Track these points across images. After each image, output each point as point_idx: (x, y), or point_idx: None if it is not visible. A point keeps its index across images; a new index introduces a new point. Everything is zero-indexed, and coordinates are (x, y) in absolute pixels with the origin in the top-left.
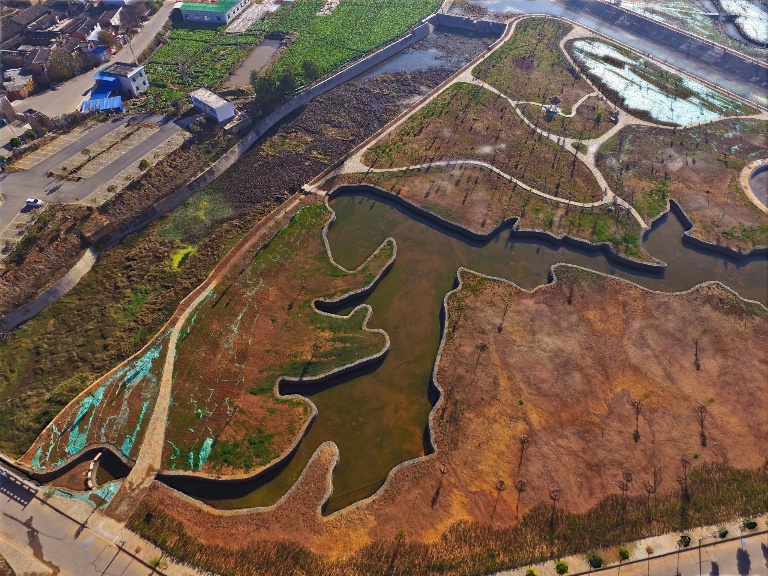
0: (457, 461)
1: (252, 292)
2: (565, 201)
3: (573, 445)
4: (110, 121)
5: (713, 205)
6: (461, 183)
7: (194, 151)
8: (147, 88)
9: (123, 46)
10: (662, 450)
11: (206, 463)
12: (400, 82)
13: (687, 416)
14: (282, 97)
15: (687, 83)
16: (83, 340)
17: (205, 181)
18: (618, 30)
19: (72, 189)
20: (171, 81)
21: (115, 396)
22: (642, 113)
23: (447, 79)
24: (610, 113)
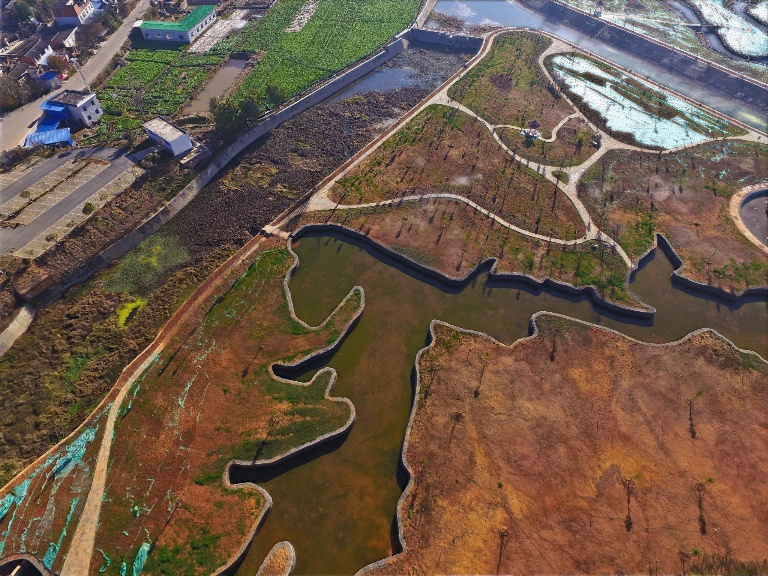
0: (428, 562)
1: (203, 356)
2: (546, 238)
3: (558, 537)
4: (56, 157)
5: (703, 239)
6: (435, 220)
7: (147, 189)
8: (100, 117)
9: (77, 70)
10: (657, 540)
11: (141, 575)
12: (372, 104)
13: (683, 496)
14: (244, 125)
15: (671, 101)
16: (12, 418)
17: (159, 222)
18: (599, 43)
19: (8, 238)
20: (127, 108)
21: (41, 492)
22: (625, 136)
23: (421, 101)
24: (592, 137)
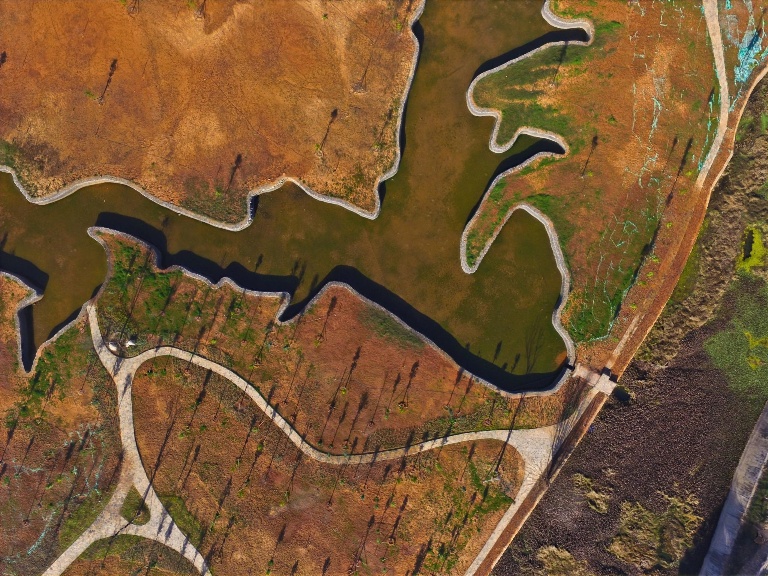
0: None
1: (648, 162)
2: (198, 359)
3: None
4: None
5: None
6: (358, 401)
7: None
8: None
9: None
10: None
11: None
12: None
13: (151, 2)
14: None
15: None
16: None
17: None
18: None
19: None
20: None
21: (764, 18)
22: None
23: None
24: None
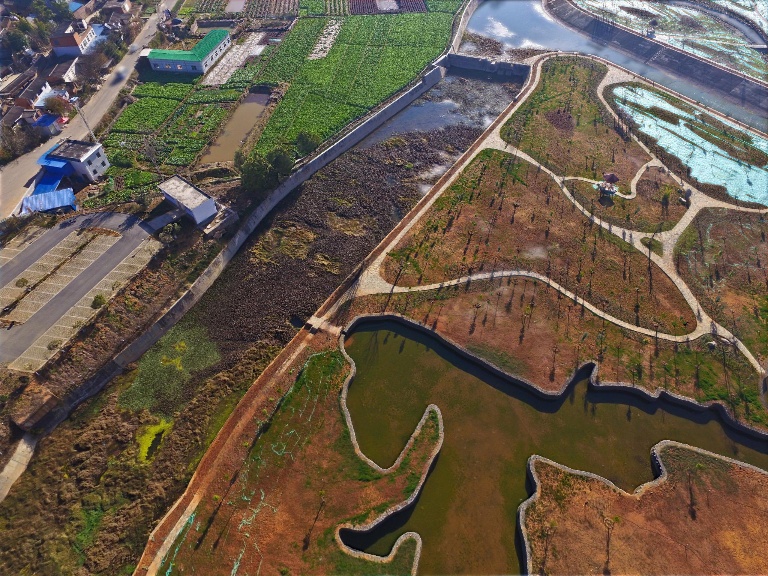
0: None
1: (250, 518)
2: (651, 333)
3: None
4: (58, 226)
5: None
6: (513, 308)
7: (166, 269)
8: (107, 169)
9: None
10: None
11: None
12: (415, 147)
13: None
14: (275, 182)
15: (757, 143)
16: None
17: (182, 310)
18: (655, 68)
19: (2, 343)
20: (137, 157)
21: None
22: (716, 190)
23: (472, 144)
24: (678, 191)
